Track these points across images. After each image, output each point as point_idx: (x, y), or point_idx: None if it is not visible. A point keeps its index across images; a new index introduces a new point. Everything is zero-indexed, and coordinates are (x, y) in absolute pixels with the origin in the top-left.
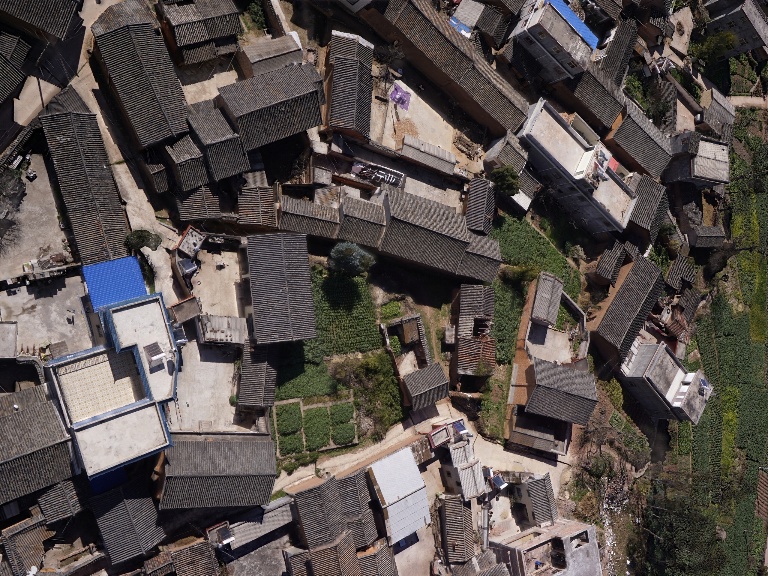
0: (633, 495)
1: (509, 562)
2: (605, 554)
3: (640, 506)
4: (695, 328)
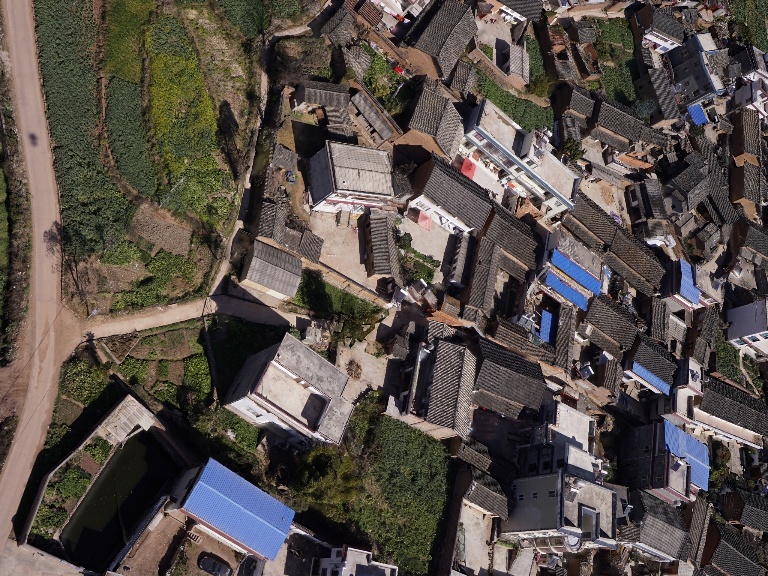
0: None
1: None
2: None
3: None
4: (314, 7)
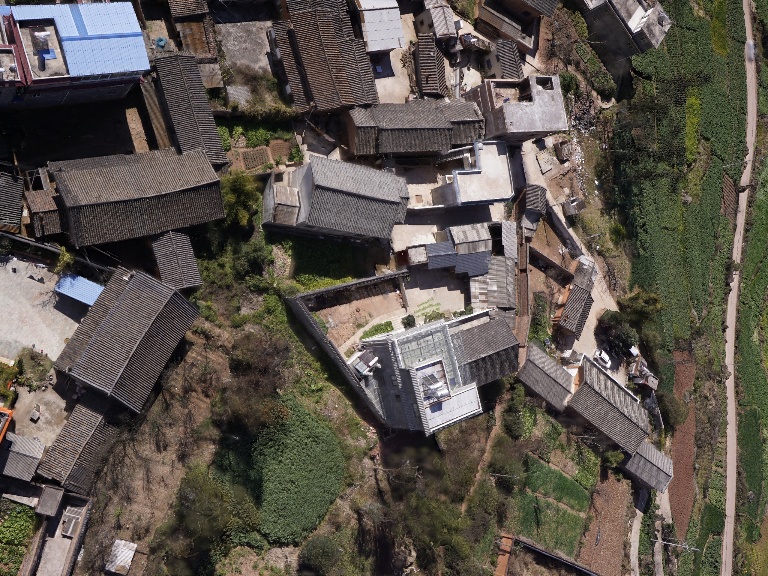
0: (600, 123)
1: (479, 98)
2: (573, 159)
3: (606, 134)
4: None
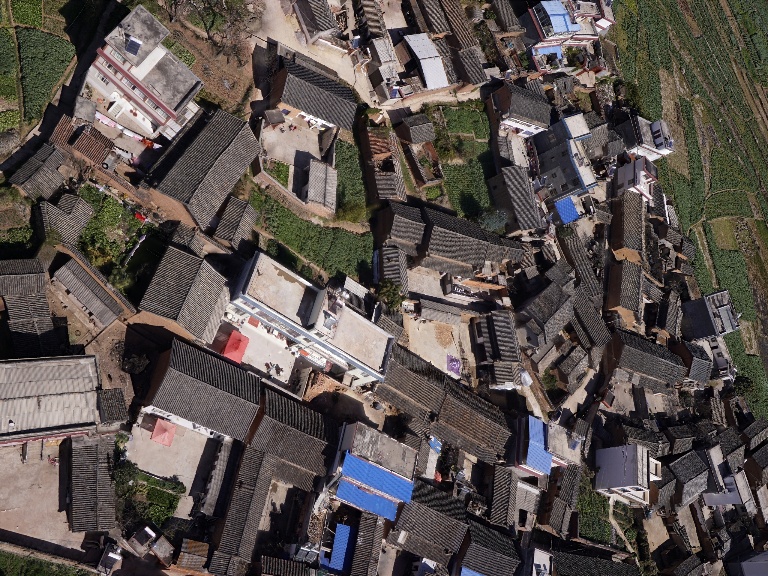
0: None
1: None
2: None
3: None
4: (6, 143)
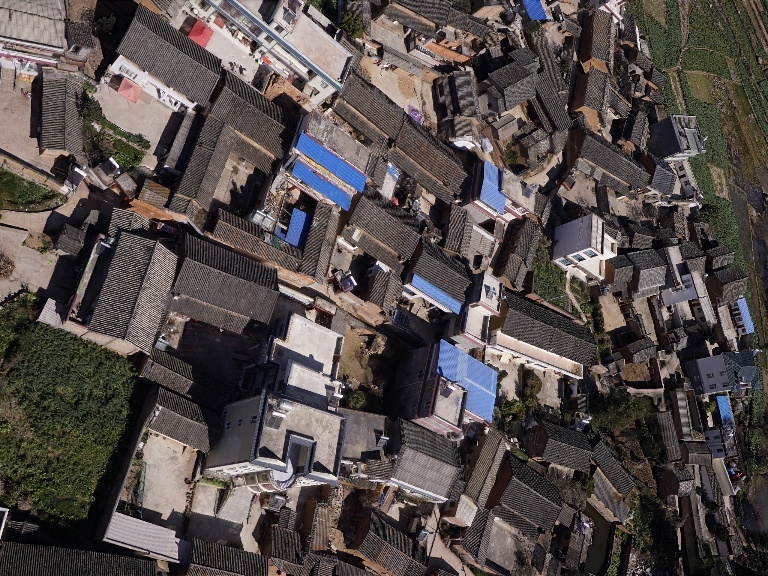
0: None
1: None
2: None
3: None
4: None
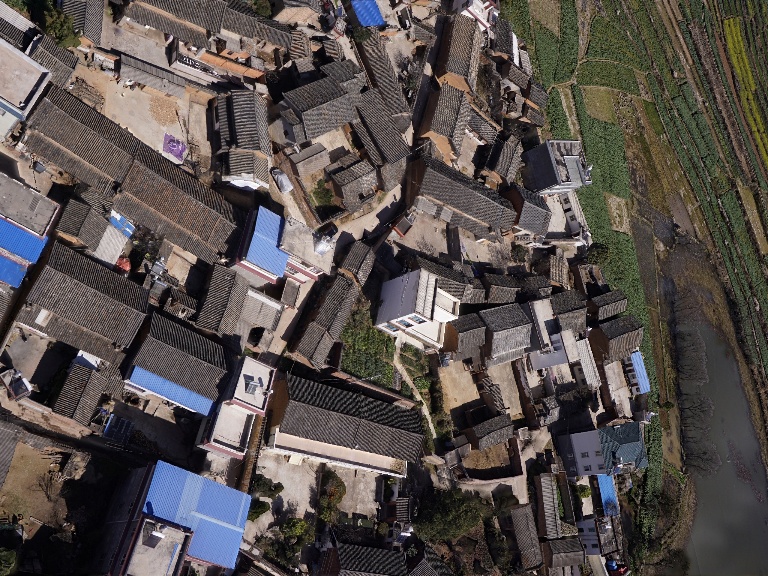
0: None
1: None
2: None
3: None
4: None
